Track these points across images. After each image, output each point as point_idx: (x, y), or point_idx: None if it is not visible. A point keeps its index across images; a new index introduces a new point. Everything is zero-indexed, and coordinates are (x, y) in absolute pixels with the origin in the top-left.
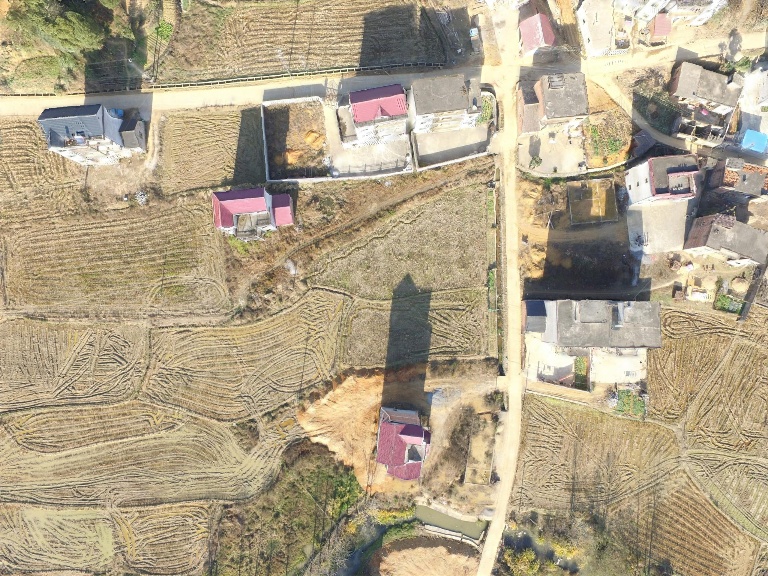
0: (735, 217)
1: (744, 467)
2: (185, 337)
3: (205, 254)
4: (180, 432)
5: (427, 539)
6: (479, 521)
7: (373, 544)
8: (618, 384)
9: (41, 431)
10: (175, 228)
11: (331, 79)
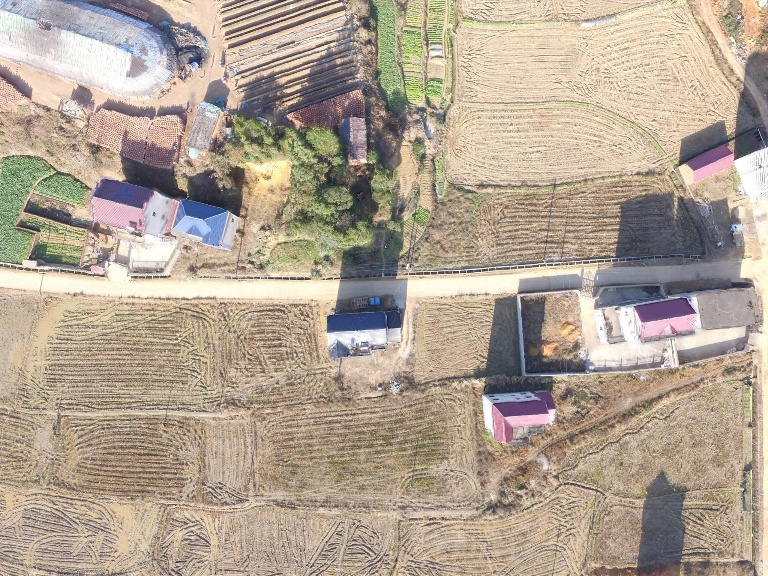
0: None
1: None
2: (434, 530)
3: (456, 445)
4: None
5: None
6: None
7: None
8: None
9: None
10: (426, 418)
11: (587, 269)
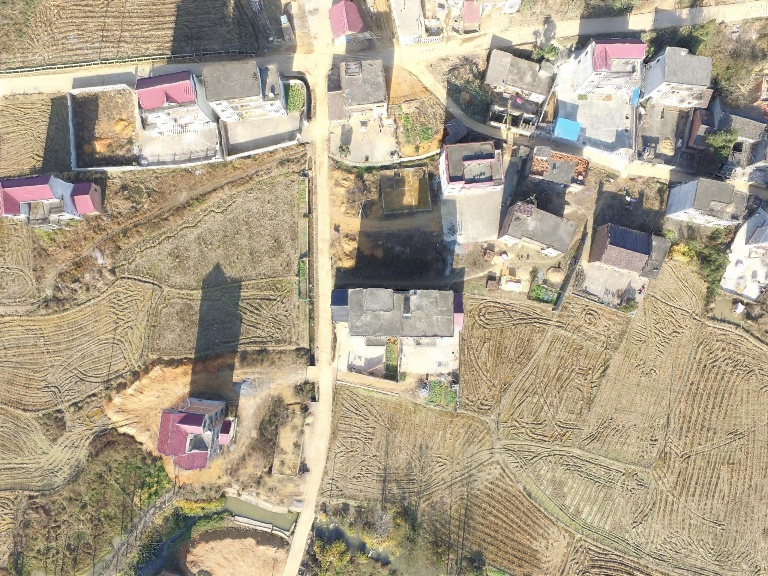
0: (534, 205)
1: (559, 458)
2: None
3: (12, 243)
4: None
5: (237, 531)
6: (289, 512)
7: (182, 535)
8: (429, 374)
9: None
10: None
11: (141, 67)
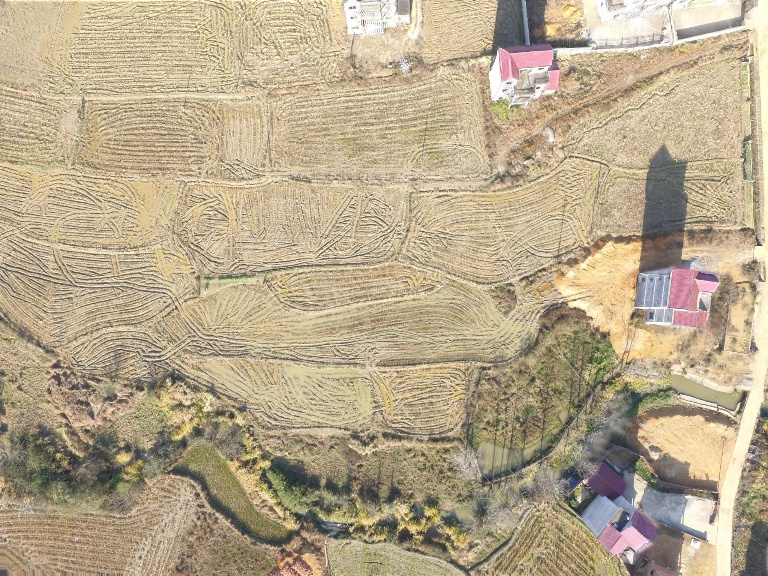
0: None
1: None
2: (444, 201)
3: (465, 122)
4: (438, 294)
5: (683, 408)
6: (736, 391)
7: (629, 411)
8: None
9: (303, 290)
10: (435, 96)
11: None
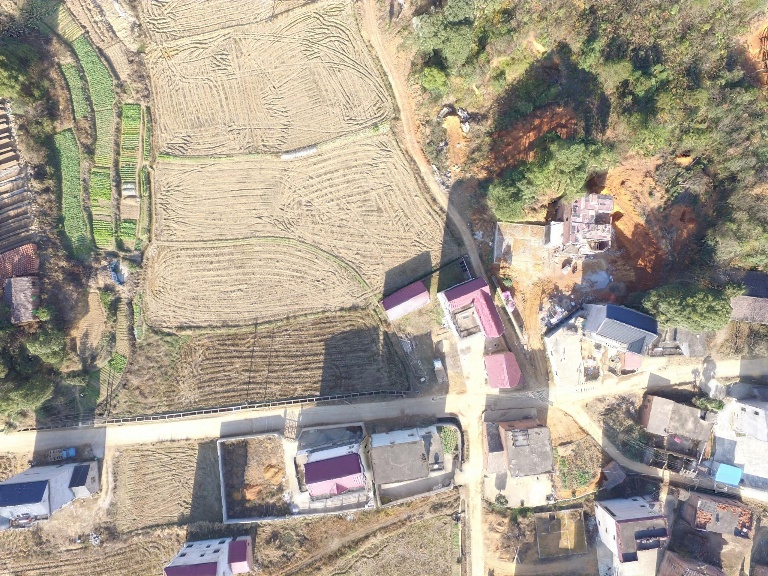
0: None
1: None
2: None
3: None
4: None
5: None
6: None
7: None
8: None
9: None
10: (130, 567)
11: (290, 410)
